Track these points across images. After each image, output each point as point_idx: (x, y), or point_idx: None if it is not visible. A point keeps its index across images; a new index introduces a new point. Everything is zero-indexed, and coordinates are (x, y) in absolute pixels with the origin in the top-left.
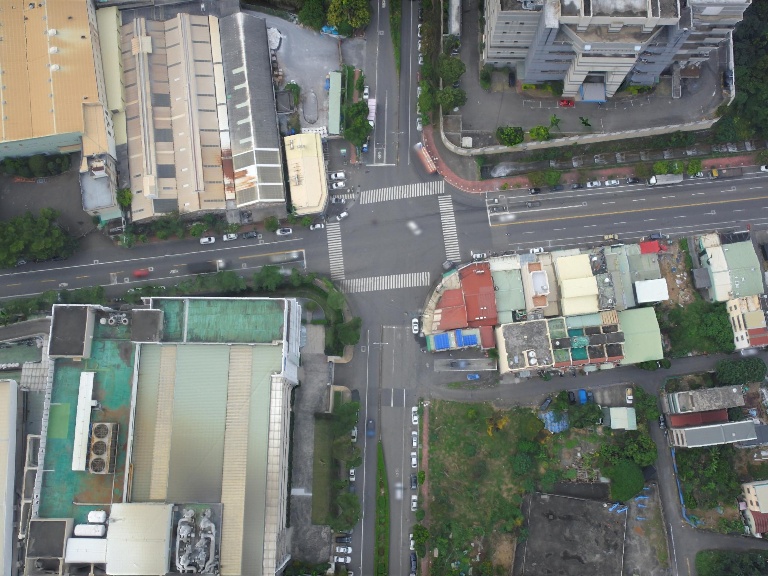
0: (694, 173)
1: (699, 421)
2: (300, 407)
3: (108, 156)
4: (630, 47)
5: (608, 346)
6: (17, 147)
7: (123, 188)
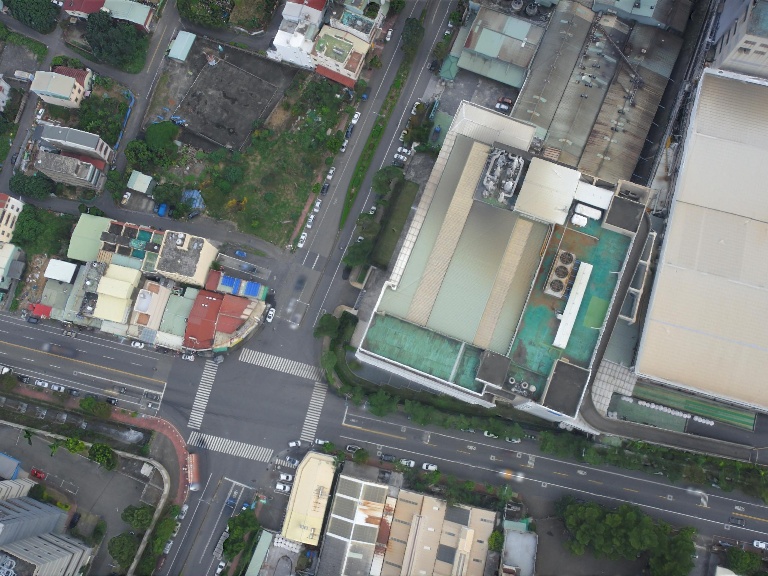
0: None
1: (83, 158)
2: None
3: None
4: None
5: None
6: None
7: (496, 552)
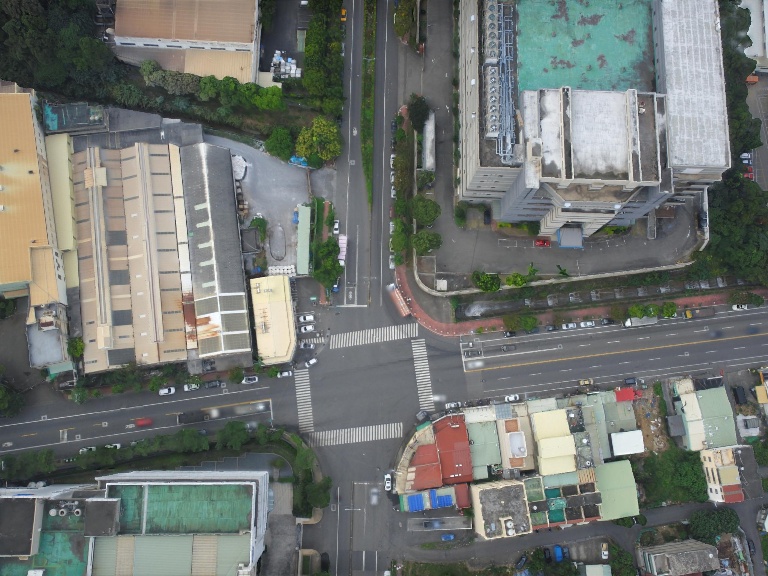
0: (669, 316)
1: None
2: (266, 574)
3: (58, 305)
4: (610, 205)
5: (585, 505)
6: None
7: (74, 337)
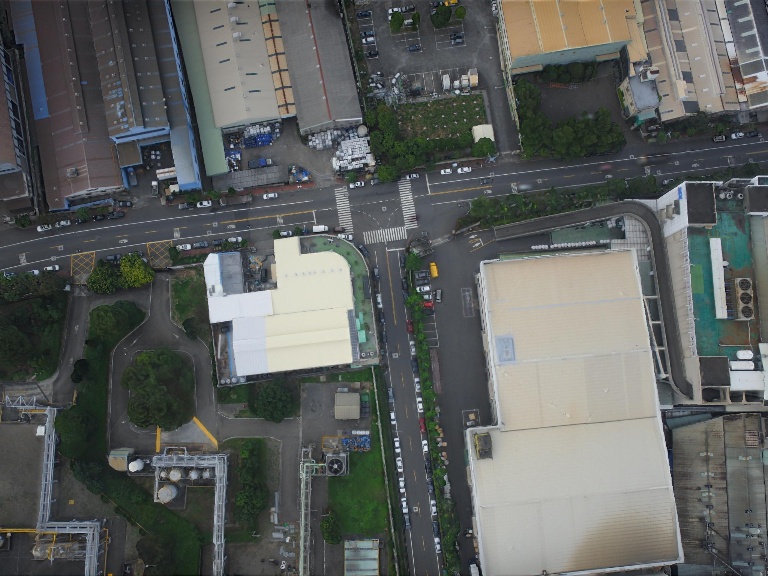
0: None
1: None
2: None
3: None
4: None
5: None
6: (568, 55)
7: None
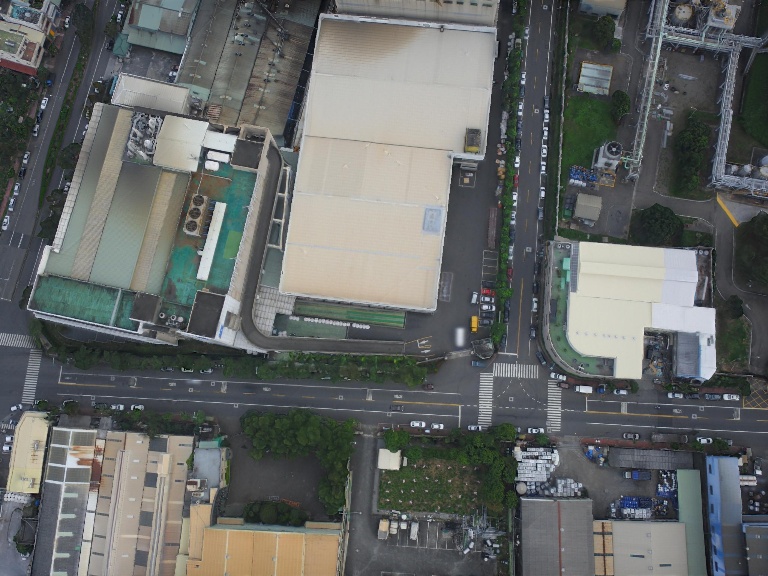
0: None
1: None
2: None
3: None
4: None
5: None
6: None
7: None
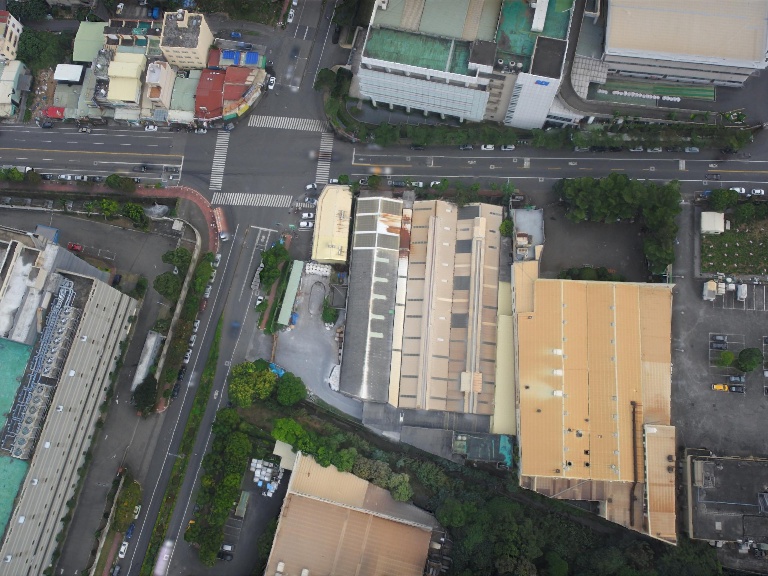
0: None
1: None
2: None
3: None
4: None
5: None
6: None
7: (507, 238)
